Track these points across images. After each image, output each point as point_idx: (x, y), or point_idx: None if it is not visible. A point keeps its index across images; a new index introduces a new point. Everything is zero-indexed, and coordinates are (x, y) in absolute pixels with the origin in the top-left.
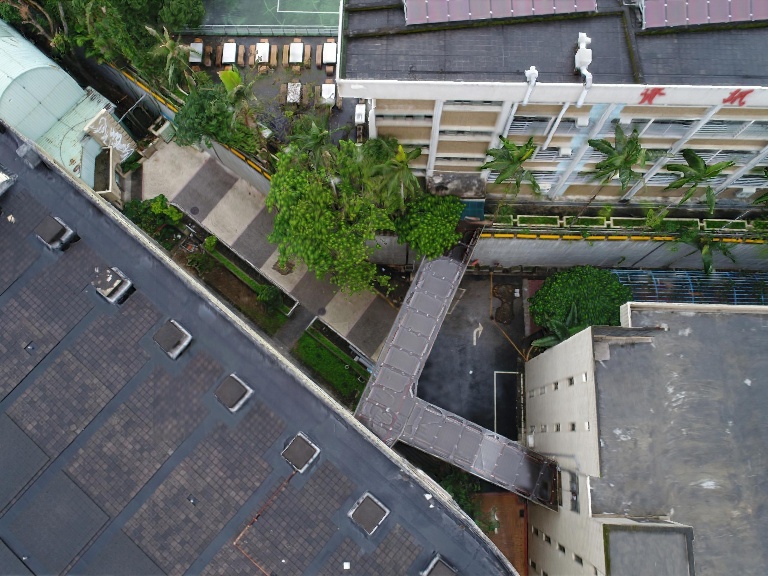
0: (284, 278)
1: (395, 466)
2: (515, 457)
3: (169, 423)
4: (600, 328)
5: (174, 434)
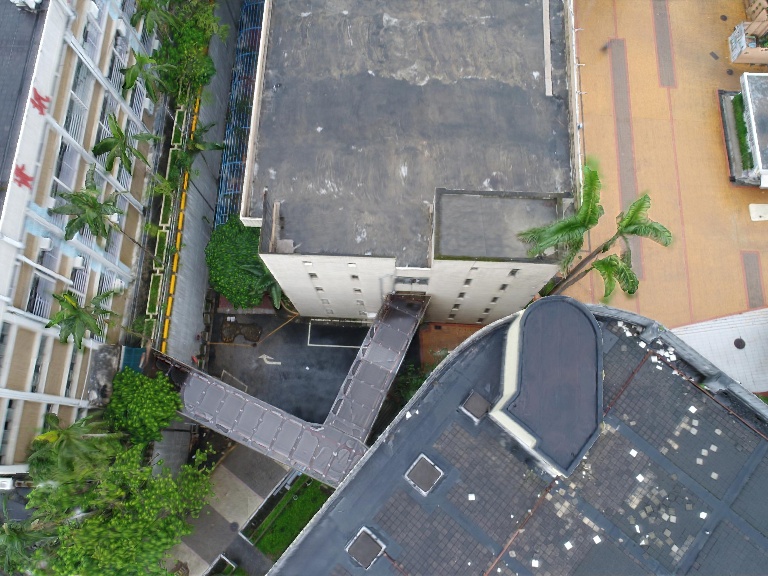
0: (192, 573)
1: (380, 448)
2: (384, 331)
3: None
4: (261, 246)
5: None
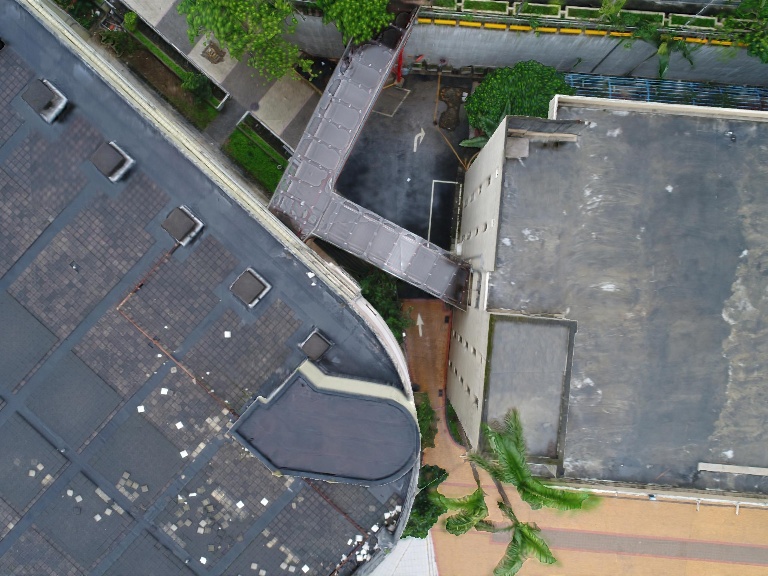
0: (214, 67)
1: (279, 244)
2: (434, 260)
3: (48, 190)
4: (516, 118)
5: (54, 201)
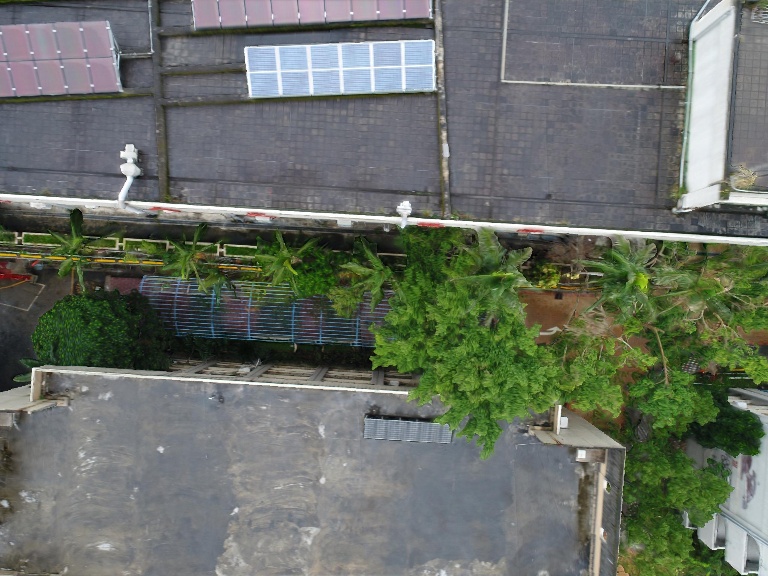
0: None
1: None
2: None
3: None
4: None
5: None
